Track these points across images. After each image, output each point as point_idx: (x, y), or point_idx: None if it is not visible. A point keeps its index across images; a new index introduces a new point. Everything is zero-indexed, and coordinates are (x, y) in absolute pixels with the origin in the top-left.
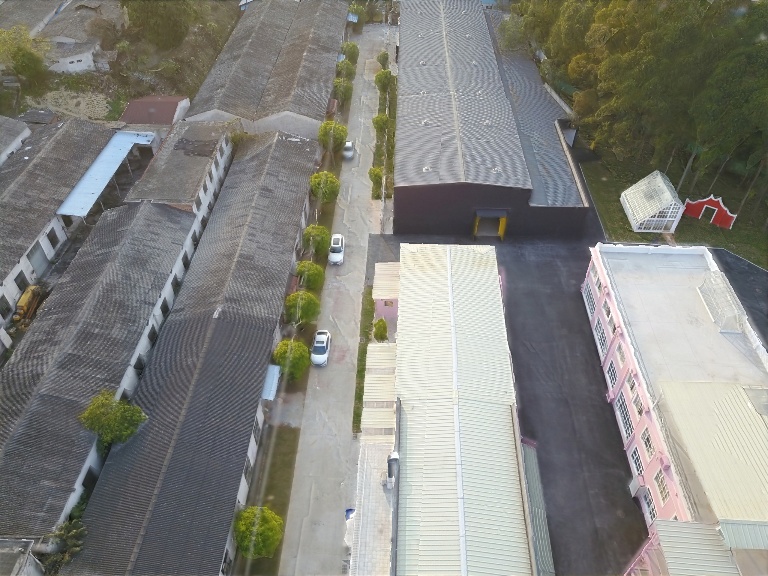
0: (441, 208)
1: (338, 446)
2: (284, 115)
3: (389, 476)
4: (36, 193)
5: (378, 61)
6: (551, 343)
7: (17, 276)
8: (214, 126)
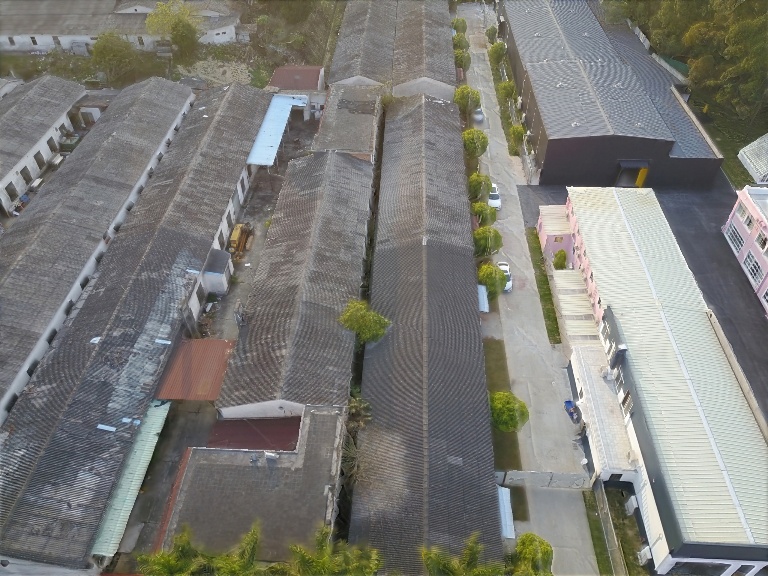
0: (587, 160)
1: (541, 354)
2: (421, 81)
3: (612, 368)
4: (226, 145)
5: (487, 35)
6: (706, 274)
7: (227, 215)
8: (367, 89)
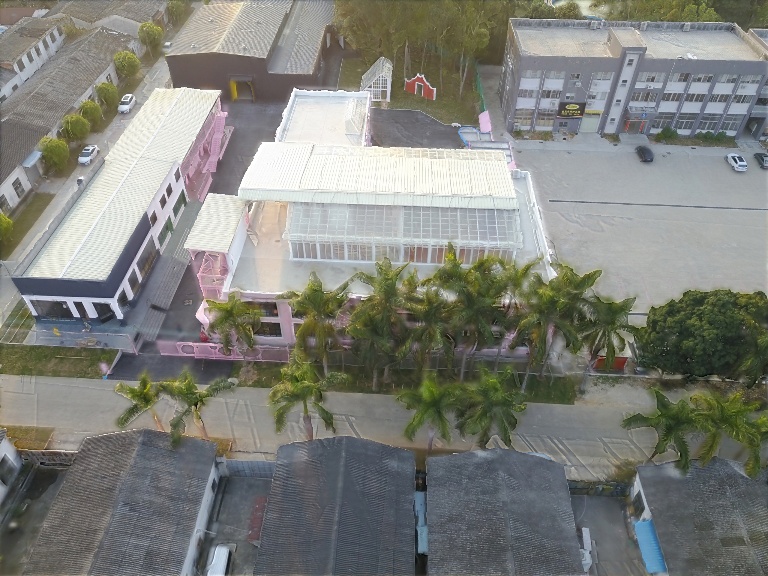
0: (205, 75)
1: None
2: (114, 19)
3: None
4: None
5: None
6: None
7: None
8: (50, 20)
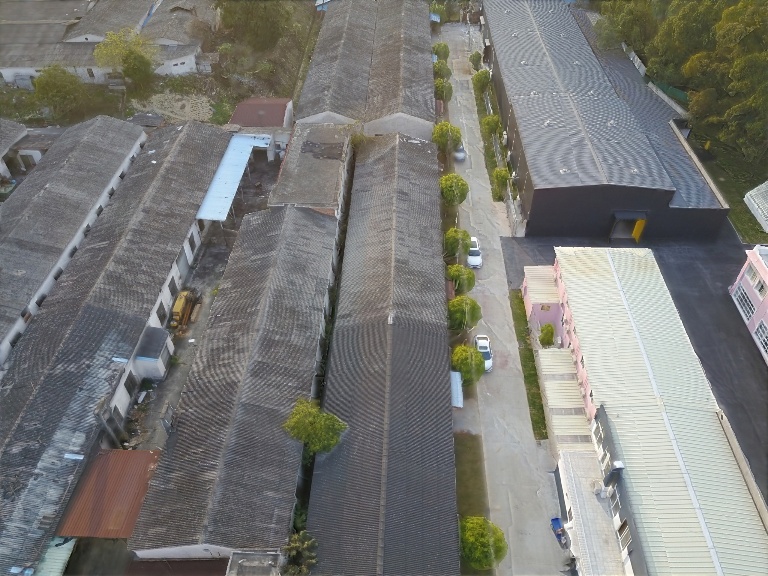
0: (578, 210)
1: (524, 453)
2: (396, 117)
3: (606, 485)
4: (173, 197)
5: (471, 61)
6: (712, 347)
7: (170, 282)
8: (335, 128)
